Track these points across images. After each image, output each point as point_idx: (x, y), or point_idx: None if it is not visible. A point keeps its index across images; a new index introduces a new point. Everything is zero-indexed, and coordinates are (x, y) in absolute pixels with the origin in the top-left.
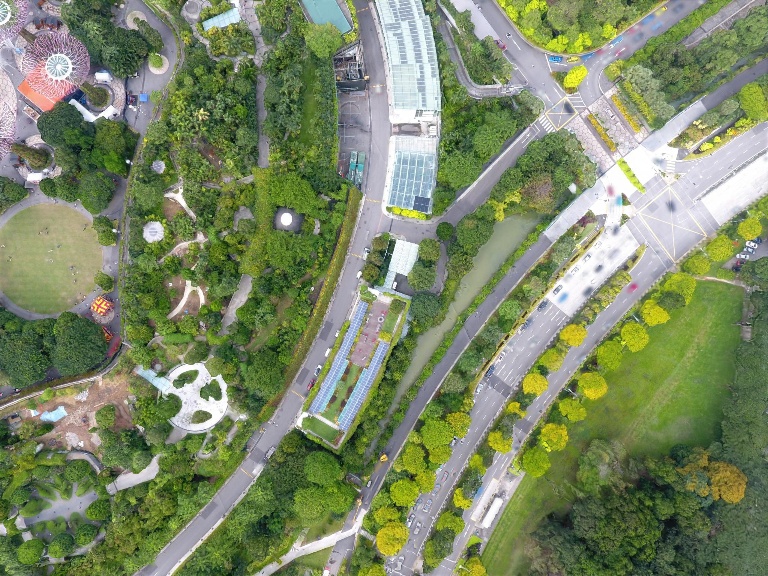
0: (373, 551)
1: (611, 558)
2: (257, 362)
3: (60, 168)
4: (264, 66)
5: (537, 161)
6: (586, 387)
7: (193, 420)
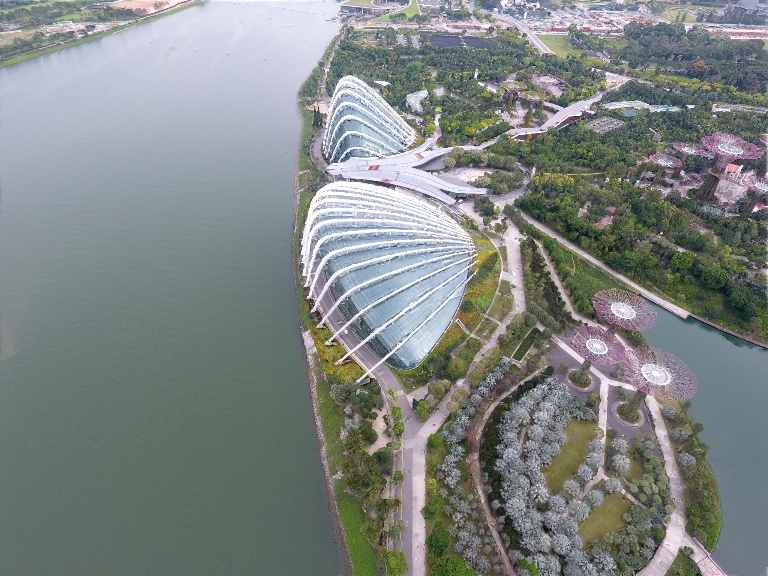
0: None
1: (743, 74)
2: None
3: (755, 173)
4: (665, 121)
5: (642, 84)
6: (698, 80)
7: None
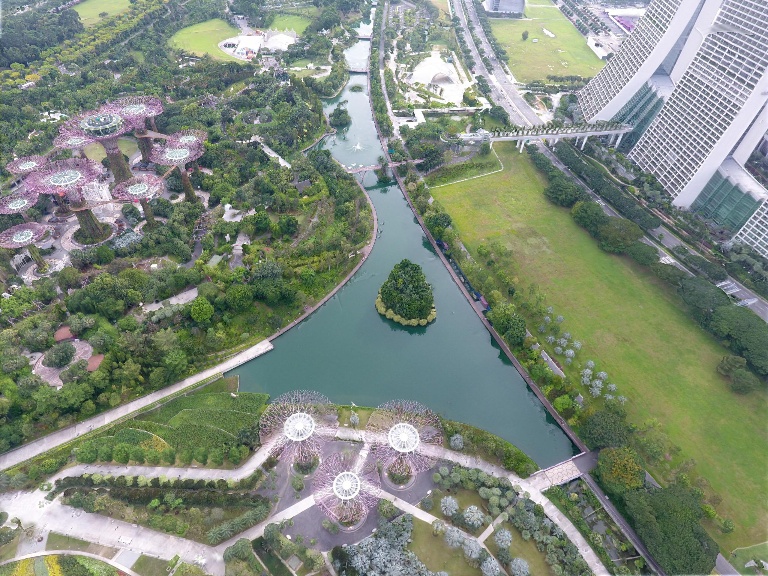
0: (2, 87)
1: None
2: (5, 110)
3: None
4: None
5: None
6: None
7: (58, 112)
